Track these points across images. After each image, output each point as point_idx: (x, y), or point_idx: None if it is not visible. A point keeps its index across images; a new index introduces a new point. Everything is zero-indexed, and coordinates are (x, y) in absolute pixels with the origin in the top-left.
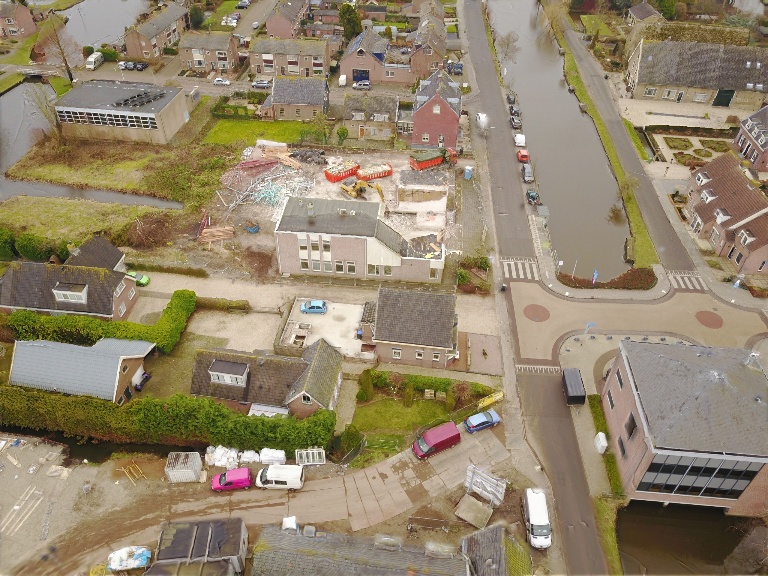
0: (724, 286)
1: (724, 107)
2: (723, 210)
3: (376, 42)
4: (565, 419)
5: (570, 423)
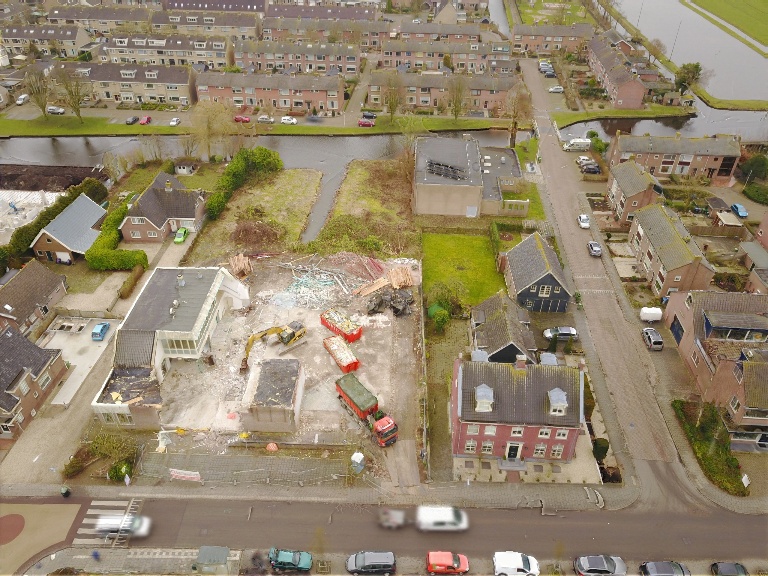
0: None
1: None
2: None
3: (759, 315)
4: None
5: None
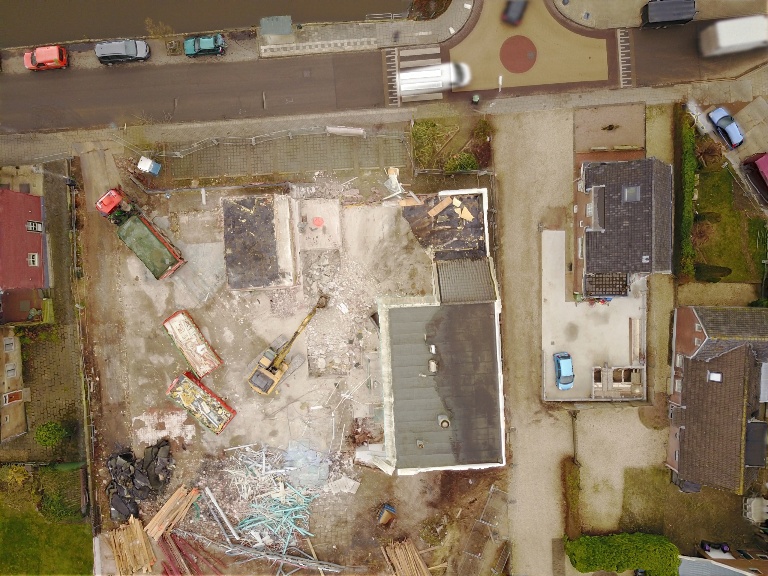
0: None
1: None
2: None
3: None
4: (700, 30)
5: (706, 24)
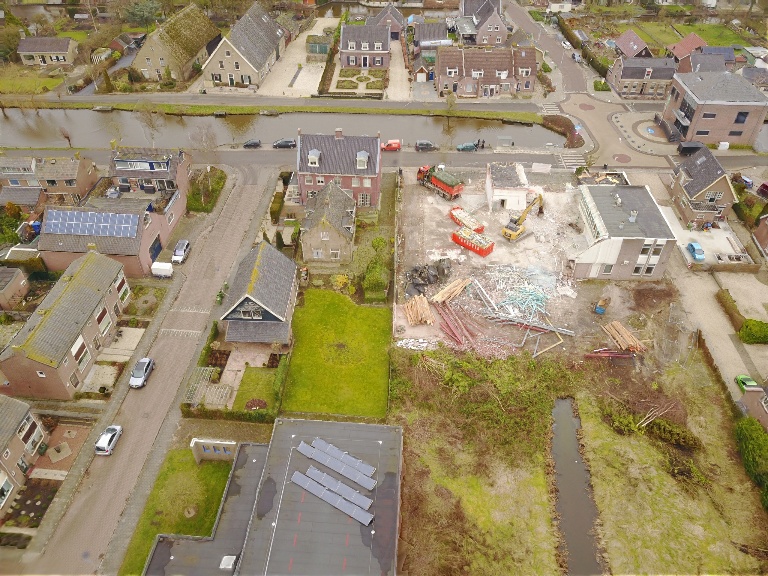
0: (549, 98)
1: (280, 58)
2: (500, 70)
3: None
4: None
5: None
